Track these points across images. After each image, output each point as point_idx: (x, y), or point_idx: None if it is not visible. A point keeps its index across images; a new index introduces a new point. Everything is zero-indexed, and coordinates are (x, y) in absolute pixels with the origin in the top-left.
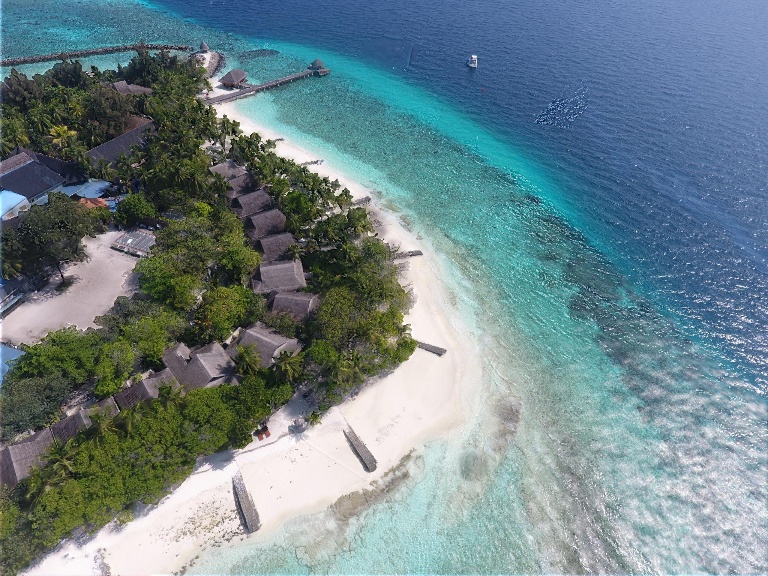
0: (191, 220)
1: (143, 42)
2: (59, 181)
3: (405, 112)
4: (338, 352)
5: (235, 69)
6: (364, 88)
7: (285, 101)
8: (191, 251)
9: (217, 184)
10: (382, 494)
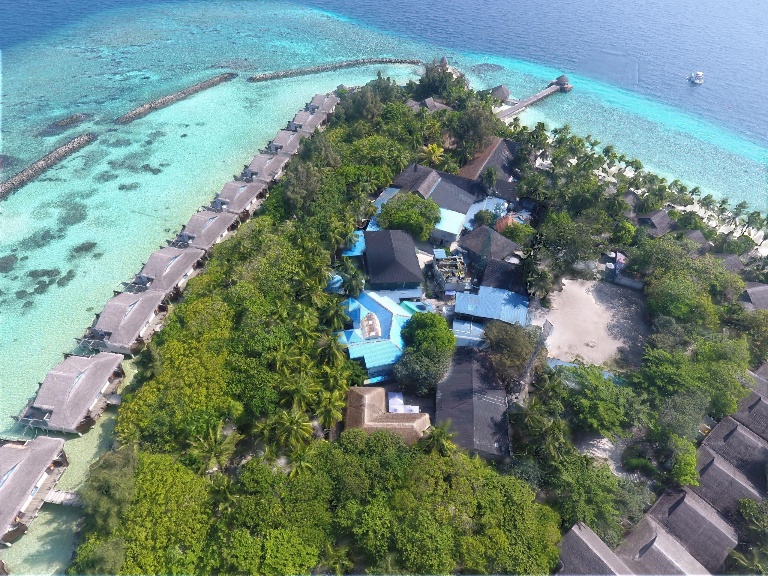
0: (672, 242)
1: (371, 56)
2: (472, 199)
3: (675, 129)
4: None
5: (480, 84)
6: (613, 104)
7: (557, 117)
8: (699, 273)
9: (647, 205)
10: None
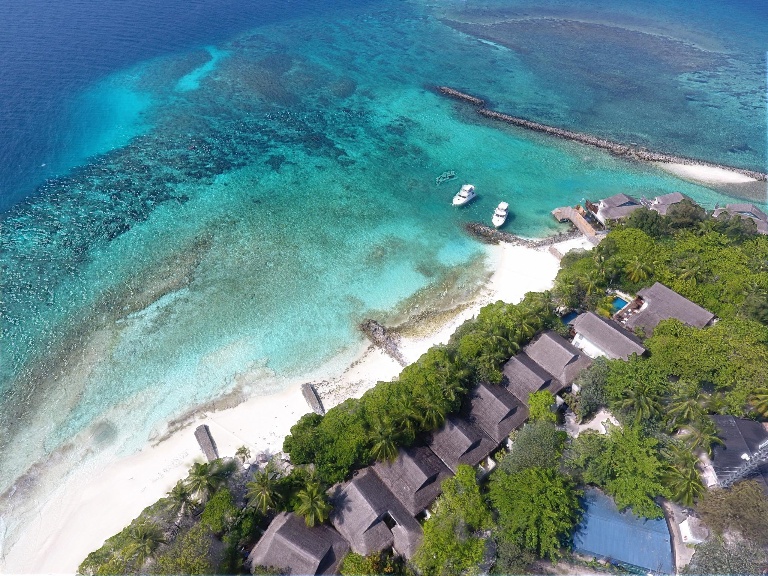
0: None
1: None
2: None
3: None
4: (198, 522)
5: None
6: None
7: None
8: None
9: None
10: (199, 409)
